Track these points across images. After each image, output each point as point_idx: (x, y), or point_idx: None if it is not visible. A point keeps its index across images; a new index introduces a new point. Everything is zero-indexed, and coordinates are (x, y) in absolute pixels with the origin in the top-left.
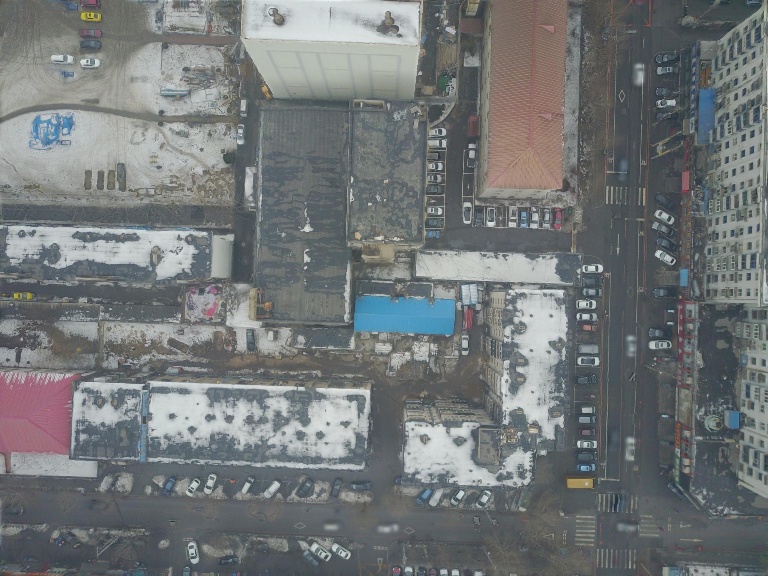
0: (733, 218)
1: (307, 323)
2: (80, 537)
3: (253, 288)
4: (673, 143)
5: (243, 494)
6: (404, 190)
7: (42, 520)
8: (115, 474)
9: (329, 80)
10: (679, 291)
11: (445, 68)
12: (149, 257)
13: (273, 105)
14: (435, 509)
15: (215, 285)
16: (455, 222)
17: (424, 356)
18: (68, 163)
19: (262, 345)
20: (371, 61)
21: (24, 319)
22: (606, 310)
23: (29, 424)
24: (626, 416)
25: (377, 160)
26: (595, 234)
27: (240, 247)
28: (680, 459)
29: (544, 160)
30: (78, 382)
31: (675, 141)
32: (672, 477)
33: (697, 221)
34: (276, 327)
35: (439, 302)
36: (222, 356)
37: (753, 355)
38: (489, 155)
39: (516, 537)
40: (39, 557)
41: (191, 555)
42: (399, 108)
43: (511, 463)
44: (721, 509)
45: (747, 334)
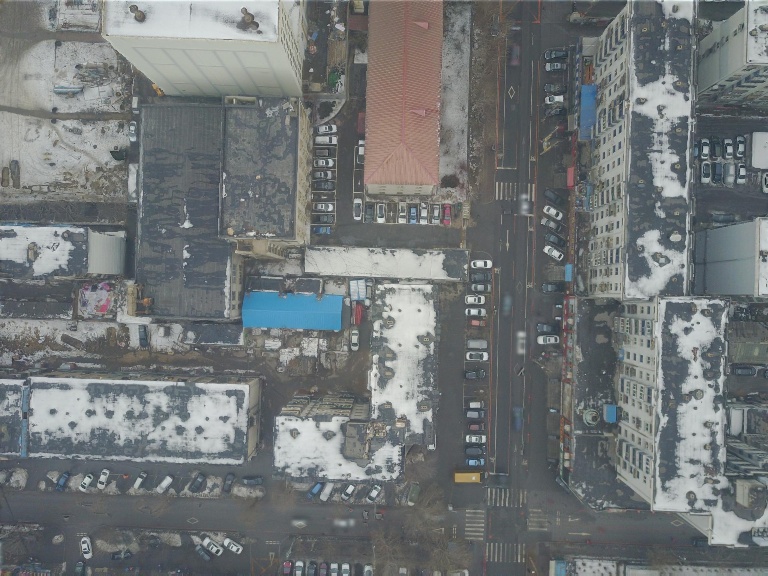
0: (607, 213)
1: (186, 319)
2: None
3: None
4: (562, 139)
5: (136, 489)
6: (276, 186)
7: None
8: (9, 470)
9: (210, 77)
10: (567, 286)
11: (336, 65)
12: (26, 253)
13: (166, 102)
14: (326, 504)
15: (108, 281)
16: (346, 218)
17: (313, 351)
18: None
19: (154, 341)
20: (239, 58)
21: None
22: (495, 305)
23: None
24: (515, 411)
25: (249, 156)
26: (485, 230)
27: (133, 244)
28: (563, 453)
29: (417, 156)
30: None
31: (564, 137)
32: (559, 471)
33: (581, 216)
34: (167, 323)
35: (327, 298)
36: (115, 352)
37: (628, 349)
38: (366, 151)
39: (400, 531)
40: None
41: (84, 550)
42: (271, 104)
43: (380, 457)
44: (600, 502)
45: (621, 328)
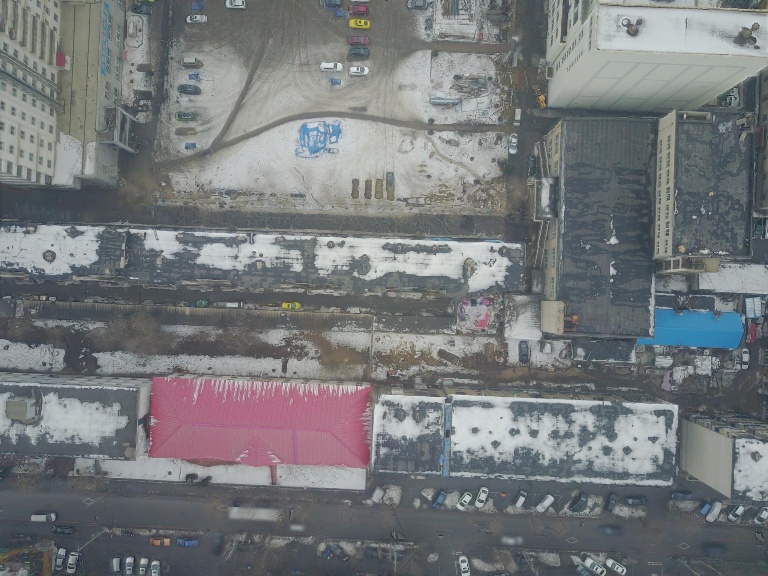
0: None
1: (615, 337)
2: (348, 550)
3: (557, 301)
4: None
5: (515, 508)
6: (729, 203)
7: (308, 532)
8: (383, 486)
9: (632, 90)
10: None
11: None
12: (462, 269)
13: (545, 114)
14: (711, 525)
15: (486, 296)
16: None
17: (707, 370)
18: (335, 172)
19: (535, 357)
20: (706, 72)
21: (293, 329)
22: None
23: (330, 437)
24: None
25: (702, 172)
26: None
27: None
28: None
29: None
30: (379, 395)
31: None
32: None
33: None
34: (552, 339)
35: (724, 315)
36: (493, 368)
37: None
38: None
39: None
40: (306, 570)
41: (463, 569)
42: (724, 120)
43: None
44: None
45: None
